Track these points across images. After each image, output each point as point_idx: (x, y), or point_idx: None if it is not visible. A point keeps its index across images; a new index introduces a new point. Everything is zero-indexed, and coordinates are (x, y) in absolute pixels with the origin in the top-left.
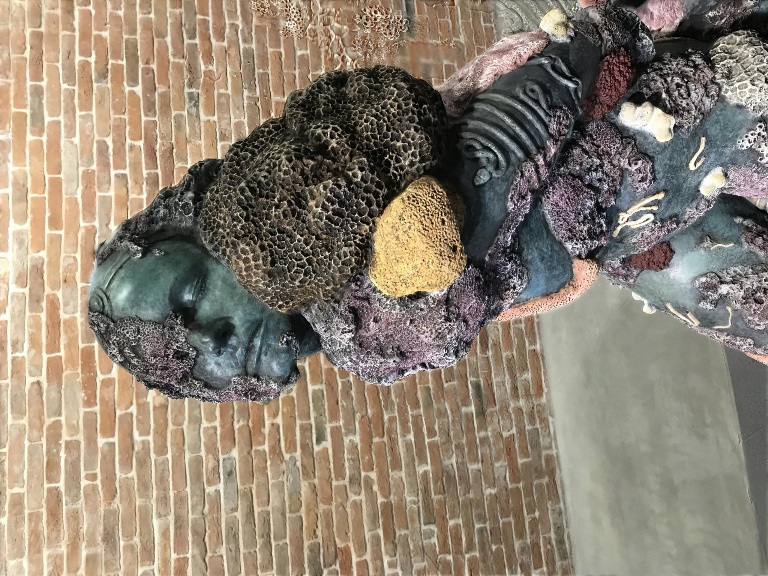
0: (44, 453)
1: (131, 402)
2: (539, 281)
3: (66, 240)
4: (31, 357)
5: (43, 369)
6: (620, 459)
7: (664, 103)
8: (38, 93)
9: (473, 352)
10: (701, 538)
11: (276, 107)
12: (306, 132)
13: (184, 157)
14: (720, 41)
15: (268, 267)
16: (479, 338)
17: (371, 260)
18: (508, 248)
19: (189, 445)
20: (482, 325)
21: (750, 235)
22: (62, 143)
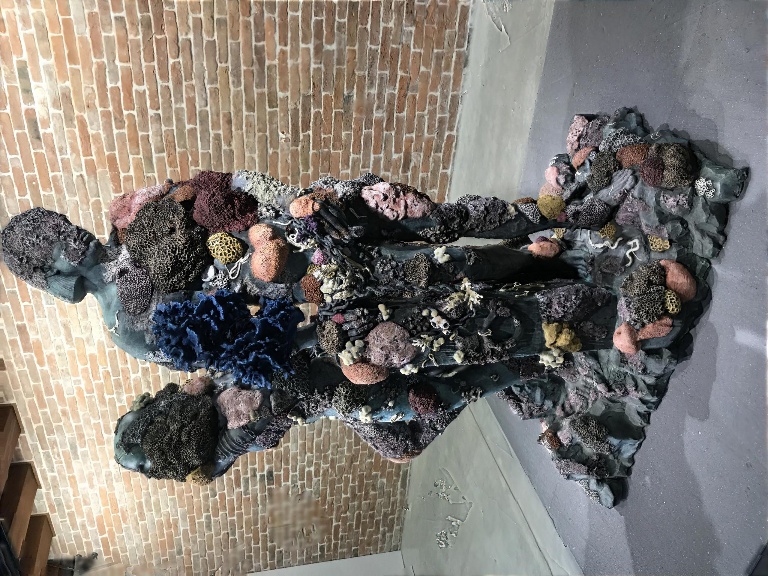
0: (92, 218)
1: None
2: None
3: (84, 74)
4: (73, 159)
5: (83, 167)
6: None
7: (305, 413)
8: None
9: (396, 172)
10: None
11: None
12: None
13: (171, 1)
14: (339, 387)
15: None
16: (403, 163)
17: (186, 480)
18: None
19: None
20: None
21: None
22: None
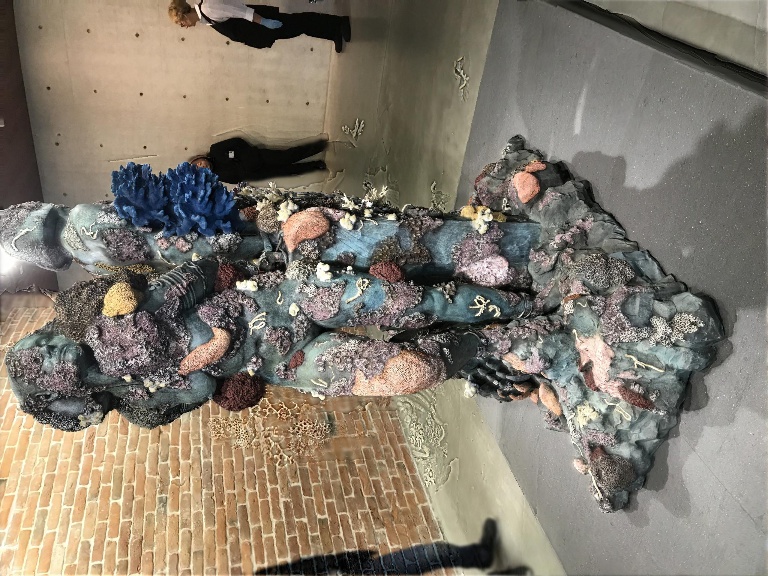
0: None
1: None
2: (197, 337)
3: None
4: None
5: None
6: None
7: None
8: (43, 515)
9: None
10: None
11: (228, 498)
12: None
13: None
14: None
15: (66, 312)
16: None
17: None
18: (174, 319)
19: None
20: (164, 345)
21: None
22: (54, 547)
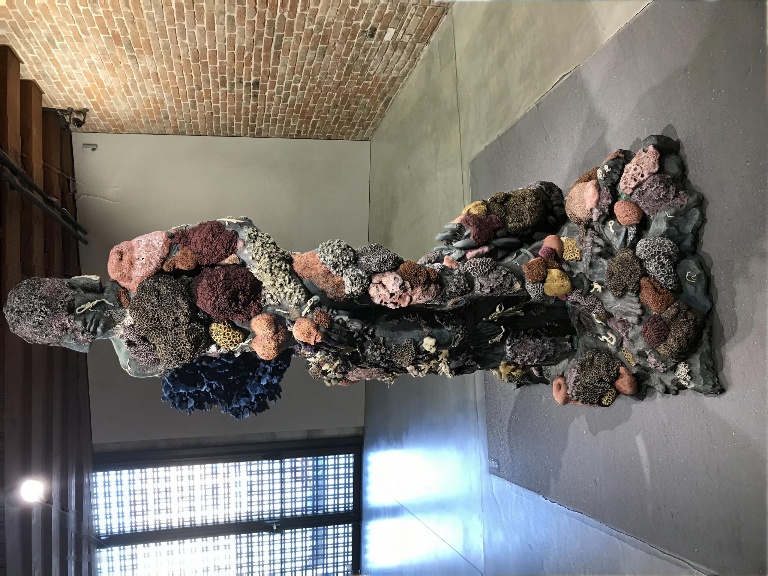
0: None
1: None
2: None
3: None
4: None
5: None
6: (506, 6)
7: None
8: None
9: None
10: (492, 93)
11: None
12: None
13: None
14: None
15: None
16: None
17: None
18: None
19: None
20: None
21: None
22: None
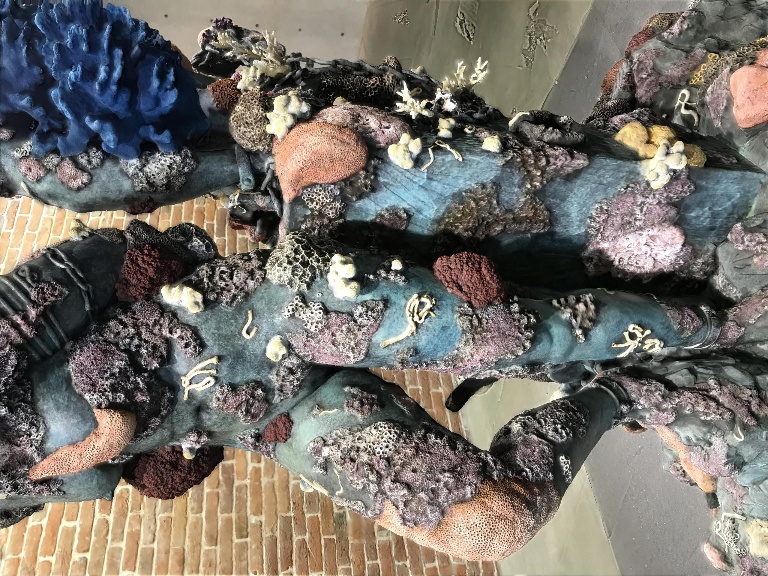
0: None
1: None
2: (59, 429)
3: None
4: None
5: None
6: None
7: (204, 285)
8: None
9: None
10: None
11: None
12: None
13: None
14: None
15: None
16: None
17: None
18: (6, 395)
19: None
20: None
21: (352, 400)
22: None
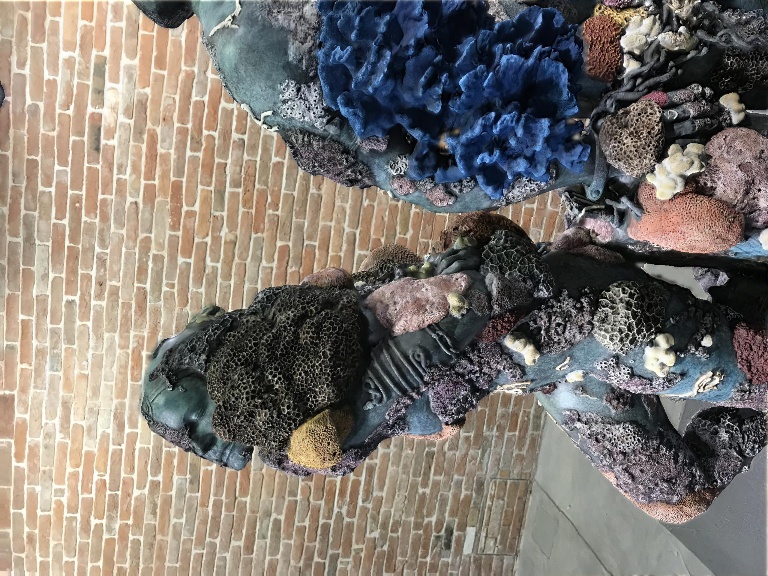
0: (136, 260)
1: (207, 233)
2: (417, 430)
3: (168, 81)
4: (132, 181)
5: (140, 192)
6: None
7: (540, 337)
8: None
9: None
10: None
11: None
12: (264, 373)
13: None
14: (612, 288)
15: None
16: None
17: (289, 445)
18: (391, 423)
19: (249, 277)
20: None
21: (611, 395)
22: None
